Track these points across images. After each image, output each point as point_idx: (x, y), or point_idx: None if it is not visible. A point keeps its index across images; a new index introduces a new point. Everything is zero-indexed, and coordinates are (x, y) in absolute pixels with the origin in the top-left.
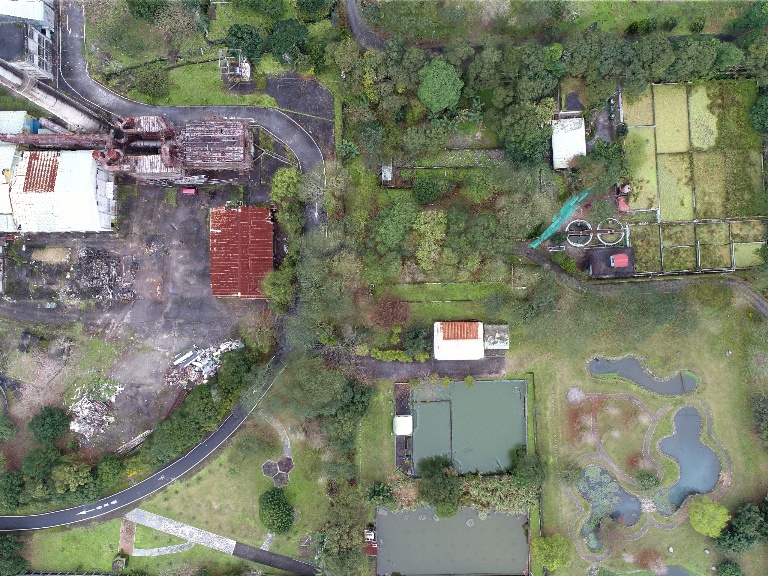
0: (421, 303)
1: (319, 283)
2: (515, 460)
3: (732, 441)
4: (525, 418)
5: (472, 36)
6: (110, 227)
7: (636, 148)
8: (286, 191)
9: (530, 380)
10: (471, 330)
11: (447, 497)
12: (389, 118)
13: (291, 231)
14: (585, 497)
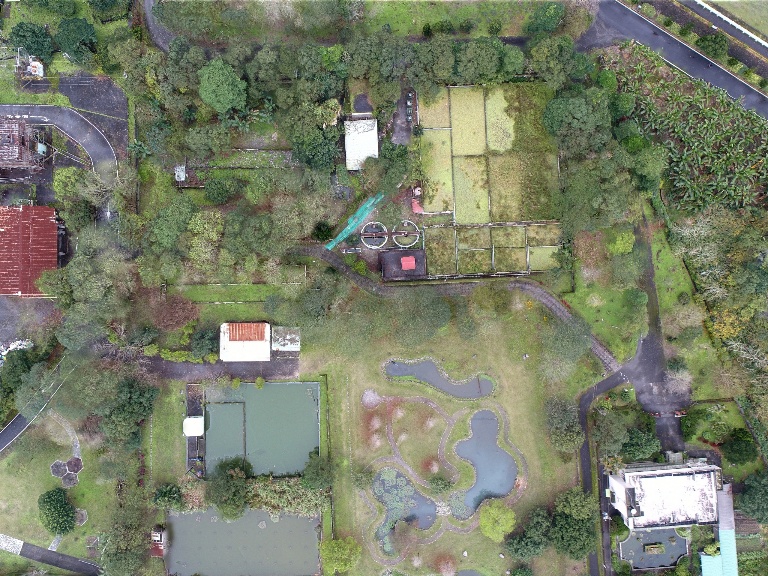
0: (214, 304)
1: (109, 283)
2: (307, 462)
3: (529, 445)
4: (318, 420)
5: (270, 37)
6: None
7: (432, 150)
8: (64, 190)
9: (323, 382)
10: (258, 331)
11: (230, 499)
12: (176, 118)
13: (71, 230)
14: (380, 500)
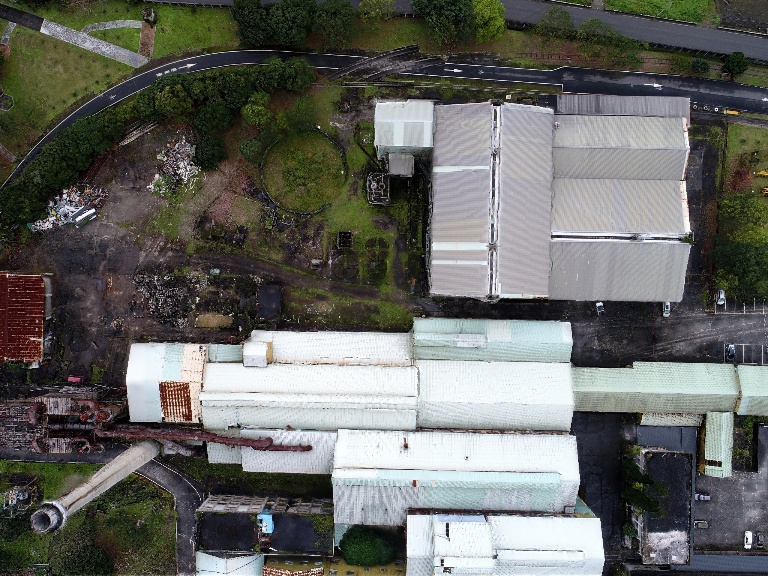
0: None
1: None
2: None
3: None
4: None
5: None
6: None
7: None
8: None
9: None
10: None
11: None
12: None
13: None
14: None
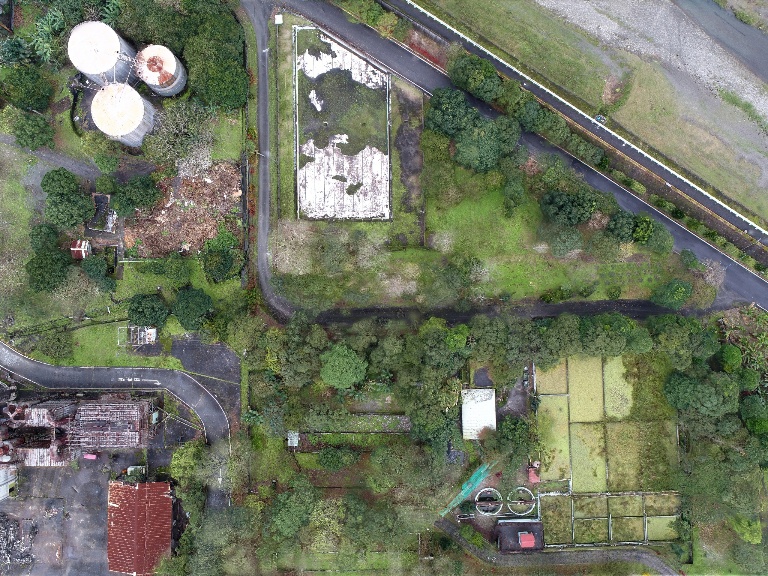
0: (325, 571)
1: None
2: None
3: None
4: None
5: (384, 298)
6: (8, 494)
7: (549, 417)
8: (183, 474)
9: None
10: None
11: None
12: (293, 391)
13: (188, 511)
14: None
